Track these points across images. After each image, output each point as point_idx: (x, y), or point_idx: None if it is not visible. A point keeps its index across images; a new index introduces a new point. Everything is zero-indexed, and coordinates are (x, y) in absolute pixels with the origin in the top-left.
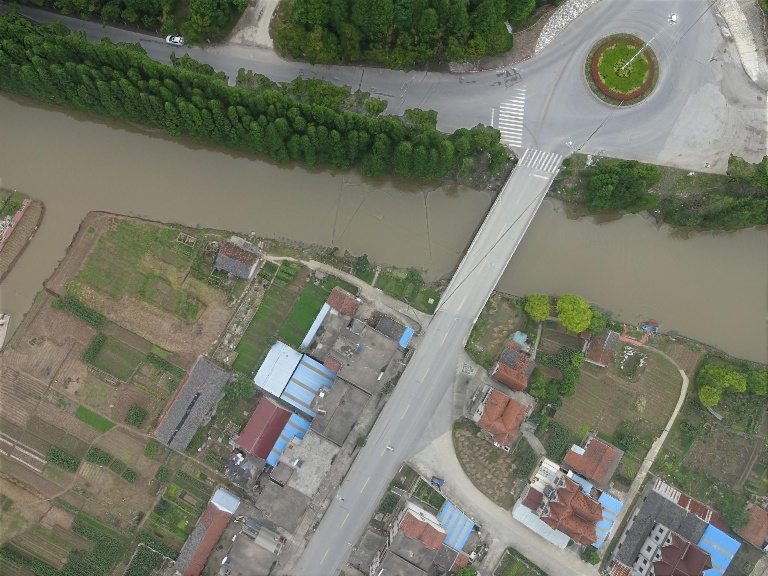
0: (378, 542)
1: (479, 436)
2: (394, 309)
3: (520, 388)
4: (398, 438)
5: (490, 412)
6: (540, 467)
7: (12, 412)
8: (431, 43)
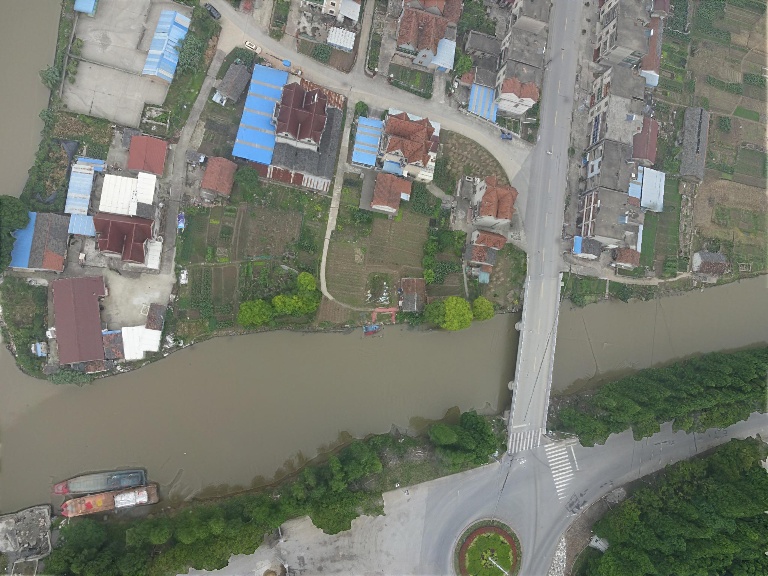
0: None
1: None
2: (586, 267)
3: None
4: (547, 163)
5: None
6: None
7: None
8: None
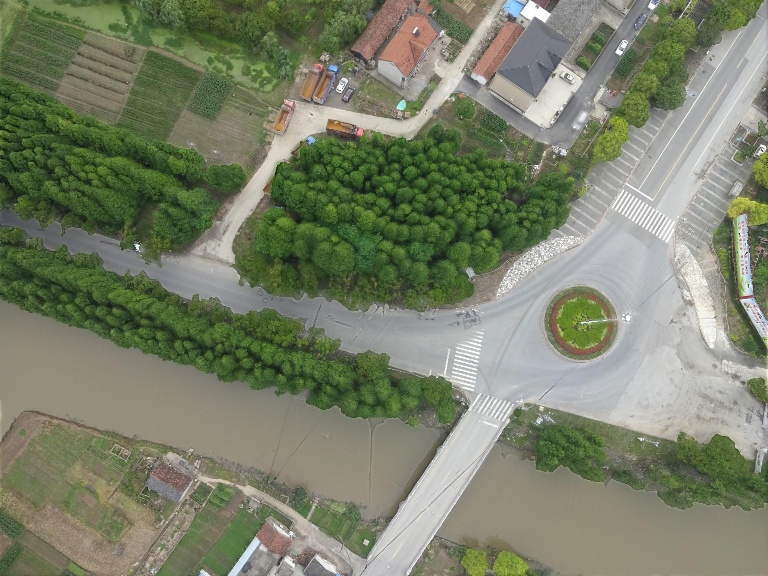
0: None
1: None
2: (327, 547)
3: None
4: None
5: None
6: None
7: None
8: (390, 289)
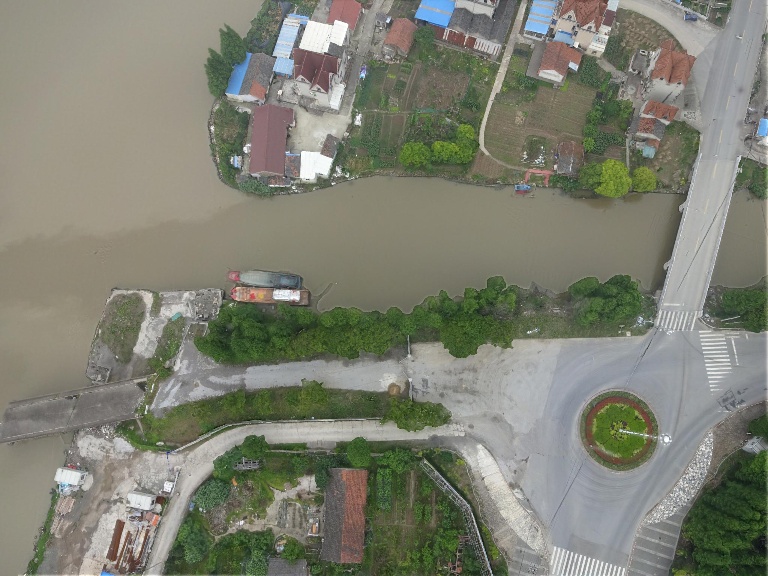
0: None
1: None
2: None
3: None
4: (735, 47)
5: None
6: None
7: None
8: None
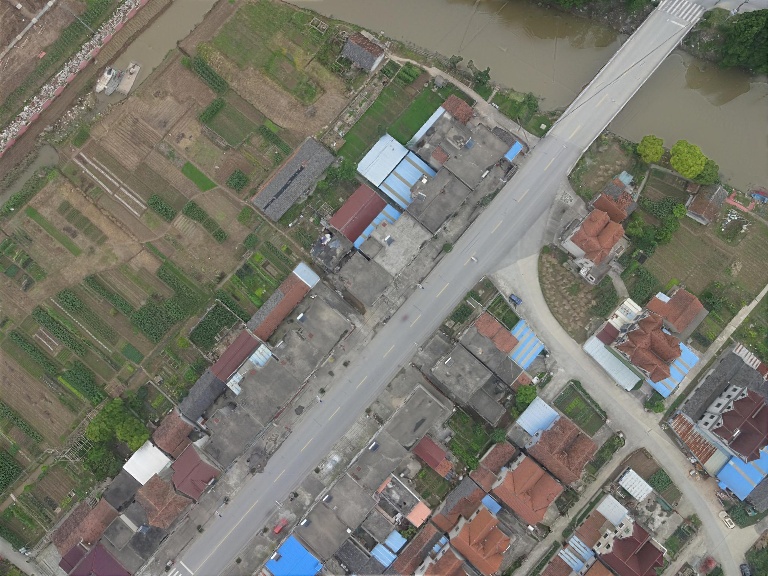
0: (444, 348)
1: (565, 266)
2: (505, 128)
3: (619, 219)
4: (484, 251)
5: (588, 227)
6: (622, 305)
7: (124, 155)
8: None
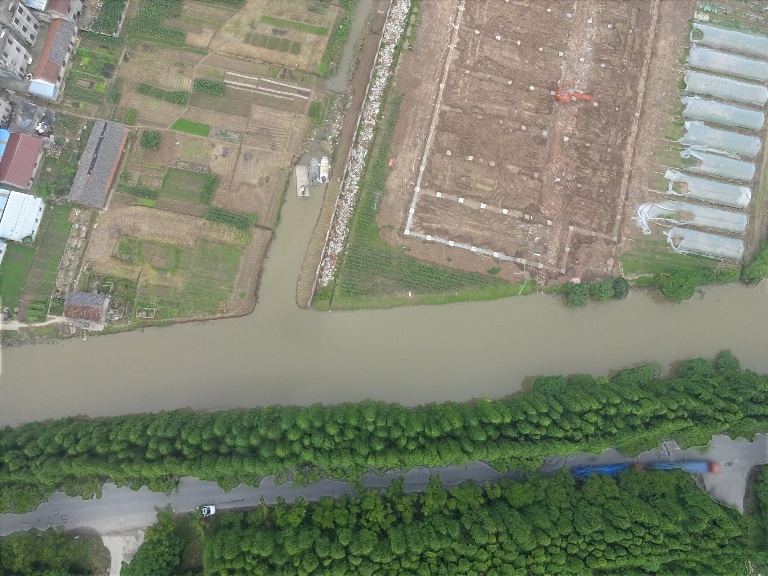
0: None
1: None
2: None
3: None
4: None
5: None
6: None
7: (268, 115)
8: None
